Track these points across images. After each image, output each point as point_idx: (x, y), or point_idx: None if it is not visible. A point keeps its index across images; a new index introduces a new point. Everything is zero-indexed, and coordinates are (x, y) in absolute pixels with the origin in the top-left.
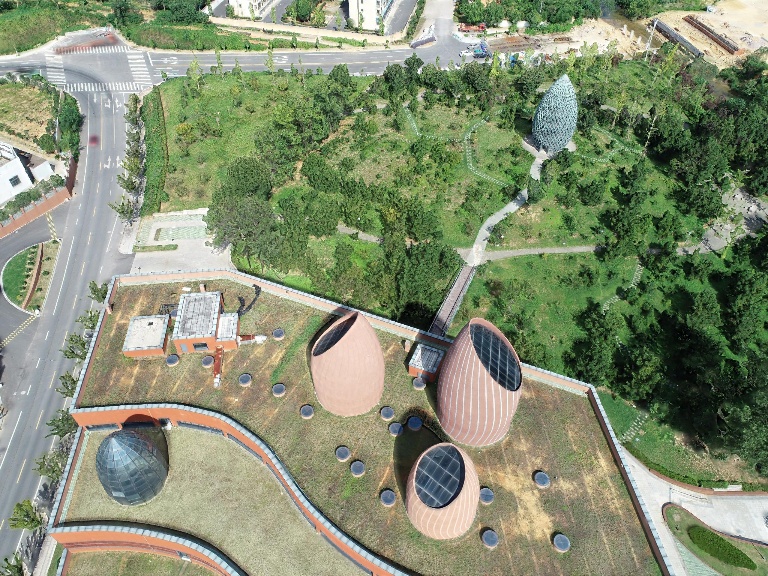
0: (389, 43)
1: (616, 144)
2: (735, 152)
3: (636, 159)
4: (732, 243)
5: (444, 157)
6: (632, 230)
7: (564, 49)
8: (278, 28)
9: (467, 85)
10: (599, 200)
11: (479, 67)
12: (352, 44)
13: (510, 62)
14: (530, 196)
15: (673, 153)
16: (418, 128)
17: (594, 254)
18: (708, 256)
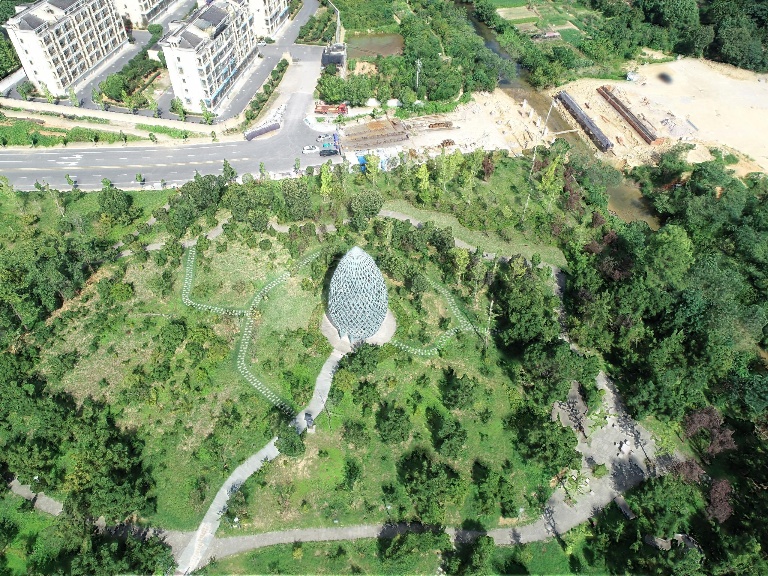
0: (219, 132)
1: (456, 318)
2: (612, 342)
3: (477, 347)
4: (587, 518)
5: (204, 349)
6: (431, 510)
7: (438, 140)
8: (82, 113)
9: (284, 210)
10: (401, 437)
11: (300, 186)
12: (171, 135)
13: (358, 166)
14: (282, 452)
15: (523, 347)
16: (192, 289)
17: (376, 544)
18: (547, 548)
